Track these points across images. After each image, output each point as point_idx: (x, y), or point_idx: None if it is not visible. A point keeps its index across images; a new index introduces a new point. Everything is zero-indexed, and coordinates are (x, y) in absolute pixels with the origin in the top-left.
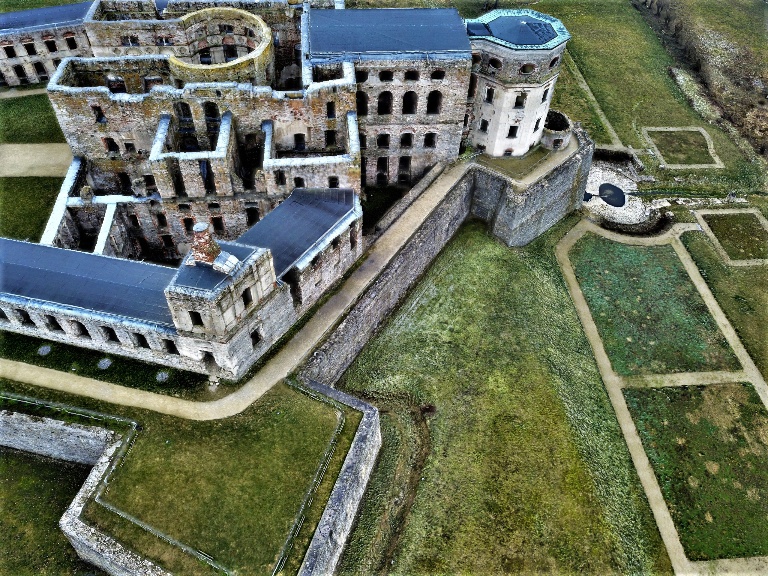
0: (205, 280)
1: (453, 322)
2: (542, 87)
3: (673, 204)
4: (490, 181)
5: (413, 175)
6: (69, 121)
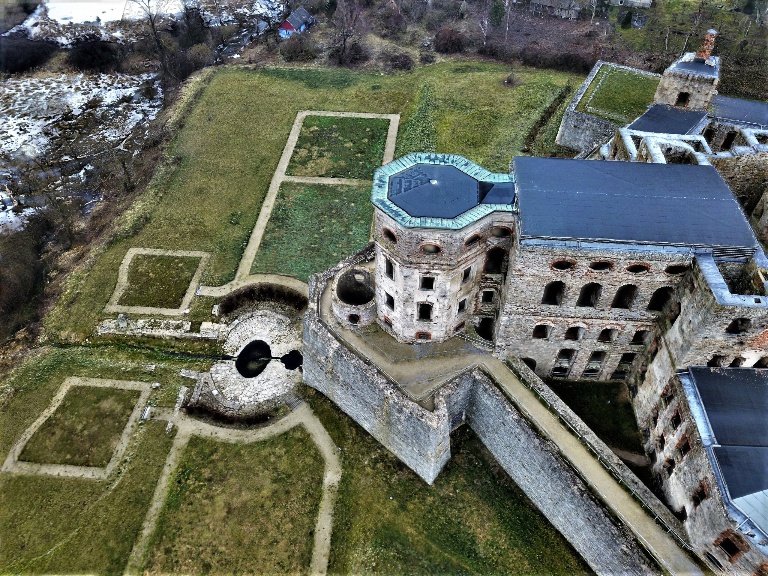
0: None
1: None
2: None
3: (197, 326)
4: None
5: None
6: None
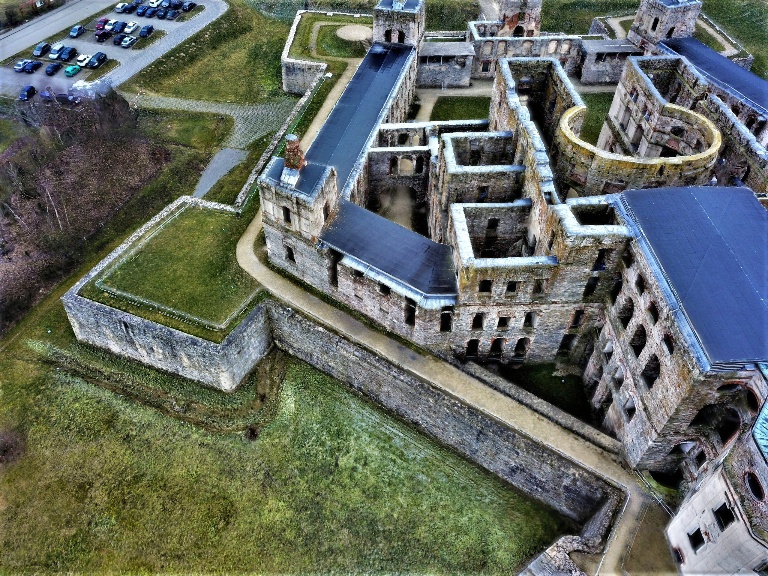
0: (276, 171)
1: (366, 472)
2: (760, 545)
3: None
4: (601, 519)
5: (605, 422)
6: (494, 91)
